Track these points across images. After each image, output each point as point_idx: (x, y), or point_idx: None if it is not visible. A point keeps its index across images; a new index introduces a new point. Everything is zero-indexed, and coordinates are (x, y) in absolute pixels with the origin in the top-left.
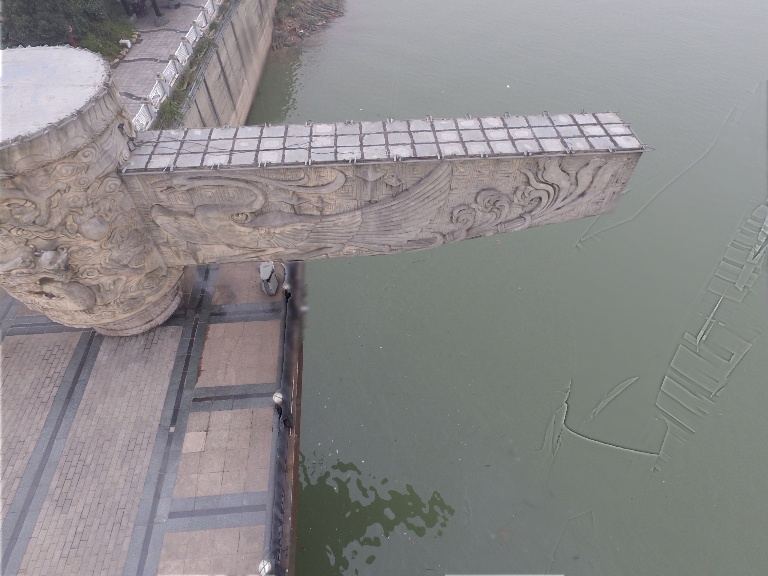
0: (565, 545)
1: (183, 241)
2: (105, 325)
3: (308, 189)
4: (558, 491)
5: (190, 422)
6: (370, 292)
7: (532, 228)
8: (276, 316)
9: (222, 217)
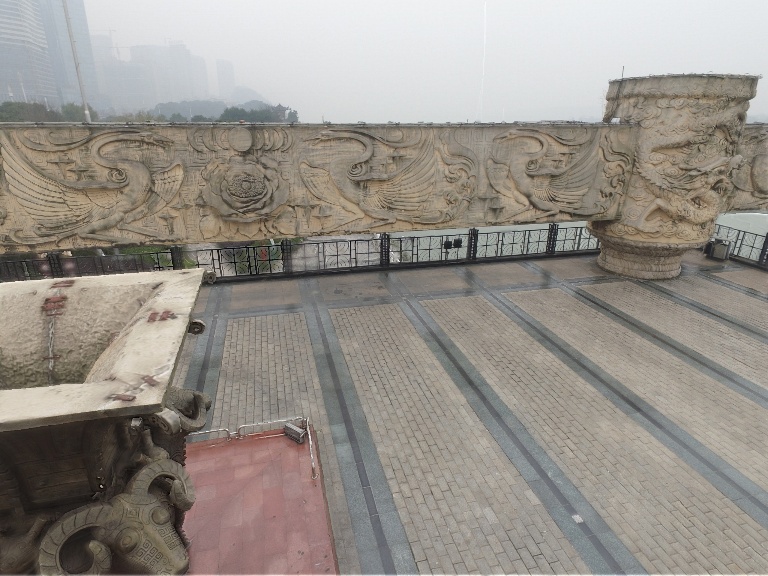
0: None
1: (732, 187)
2: (697, 245)
3: None
4: None
5: None
6: None
7: None
8: (746, 268)
9: (767, 163)
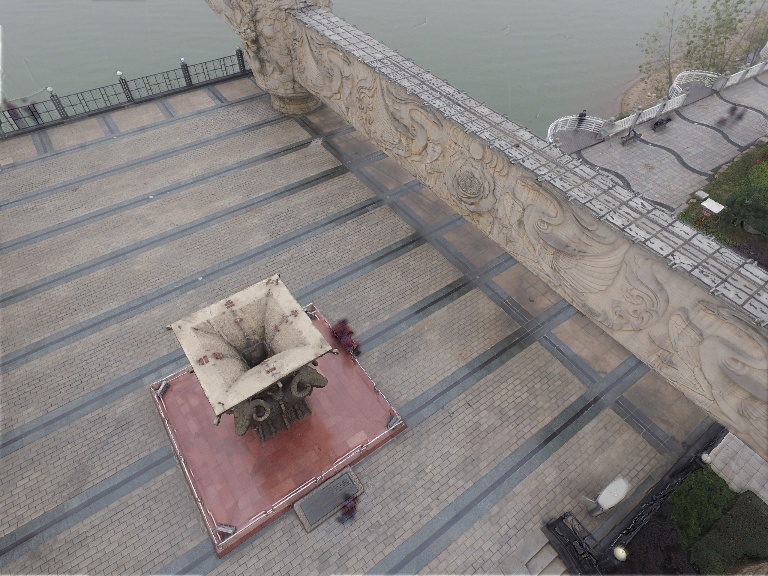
0: None
1: None
2: None
3: None
4: (20, 74)
5: None
6: None
7: None
8: None
9: None
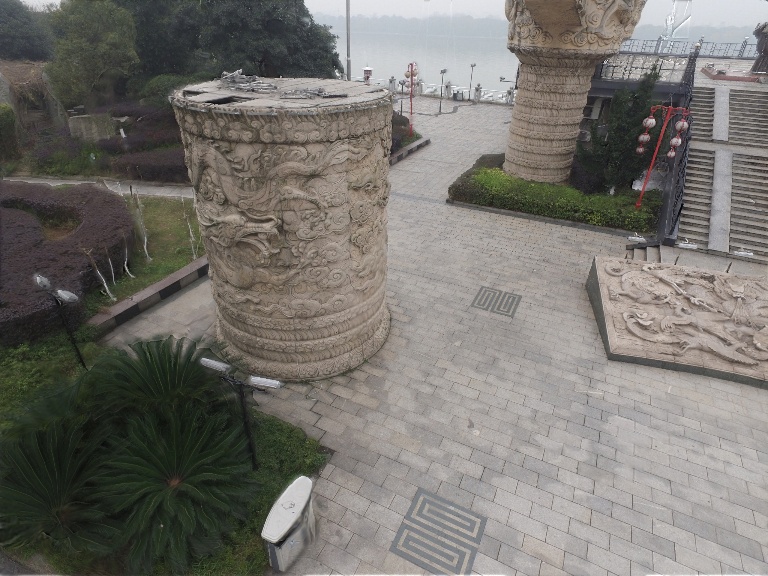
0: None
1: None
2: None
3: None
4: None
5: None
6: None
7: None
8: None
9: None
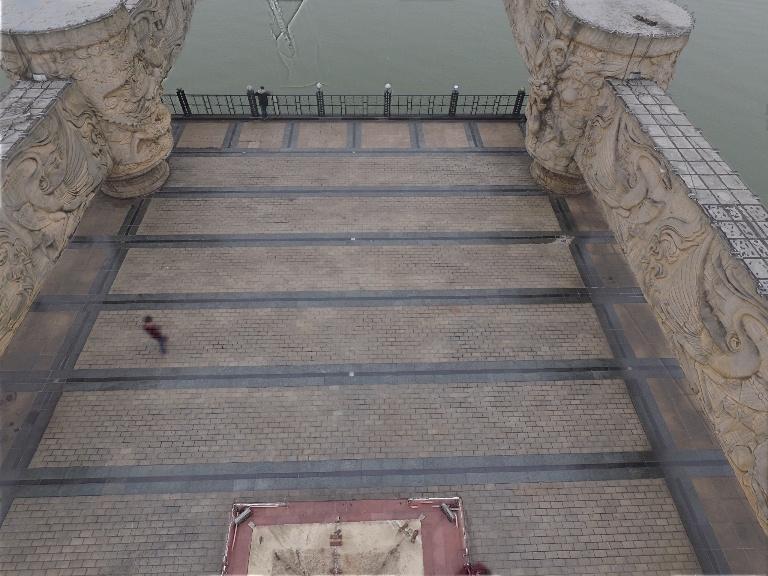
0: (325, 73)
1: None
2: None
3: (155, 8)
4: None
5: (242, 147)
6: (197, 69)
7: (196, 2)
8: (183, 125)
9: None
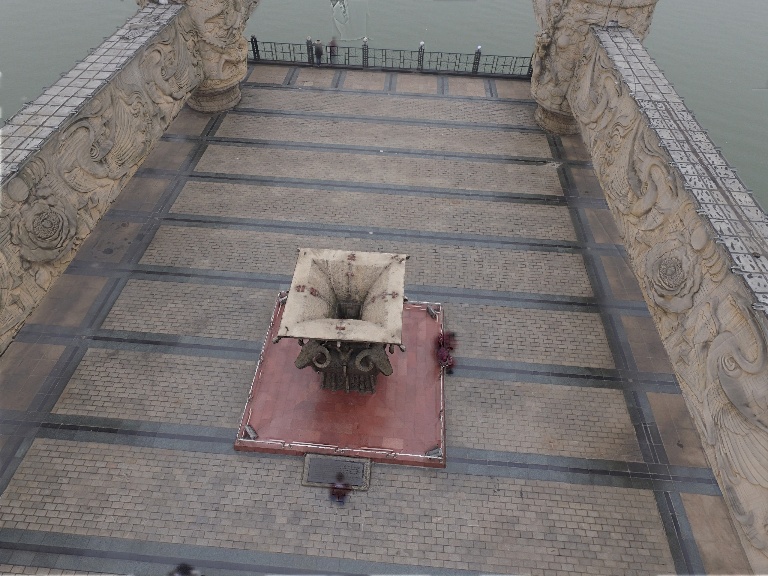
0: None
1: None
2: None
3: None
4: (358, 23)
5: (299, 85)
6: (267, 24)
7: None
8: (253, 67)
9: None
